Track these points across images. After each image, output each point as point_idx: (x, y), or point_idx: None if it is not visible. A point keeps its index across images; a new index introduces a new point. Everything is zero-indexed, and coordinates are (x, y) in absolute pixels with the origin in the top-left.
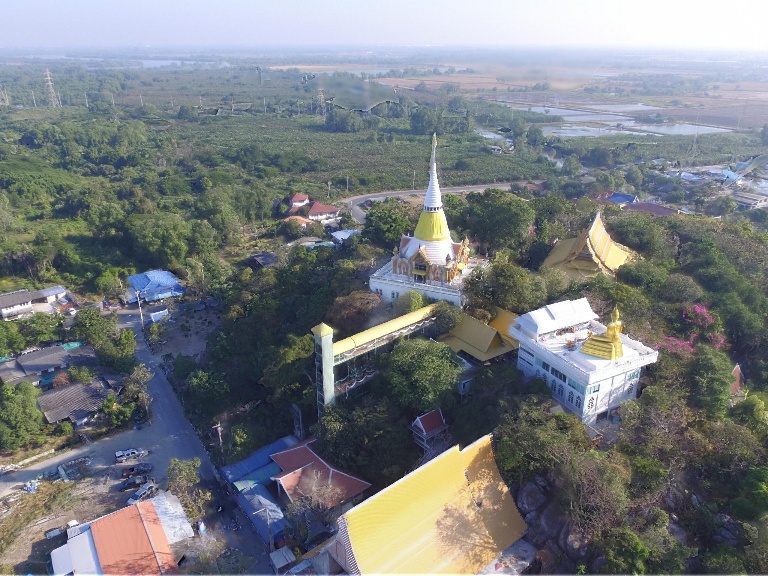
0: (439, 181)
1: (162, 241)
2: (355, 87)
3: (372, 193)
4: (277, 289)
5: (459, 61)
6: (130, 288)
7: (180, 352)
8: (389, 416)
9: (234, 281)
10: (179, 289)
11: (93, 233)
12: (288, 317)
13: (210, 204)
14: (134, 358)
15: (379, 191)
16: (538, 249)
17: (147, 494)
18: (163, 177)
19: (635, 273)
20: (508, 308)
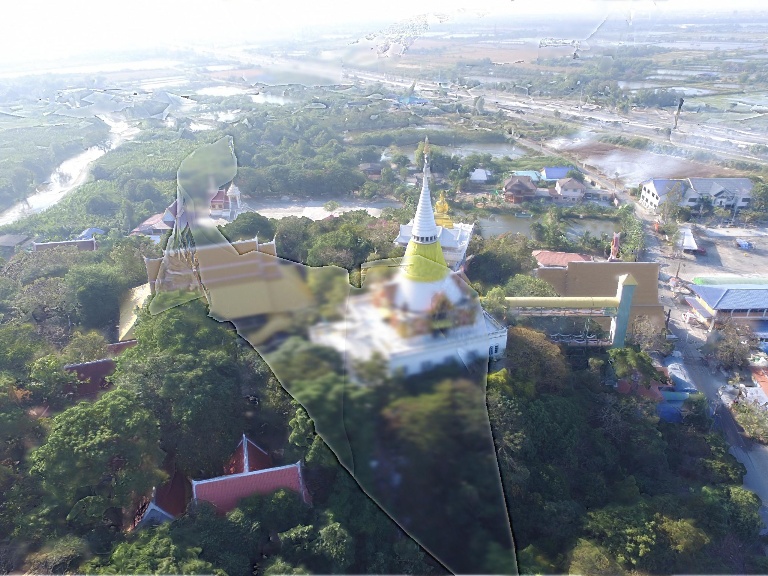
0: None
1: None
2: None
3: None
4: None
5: None
6: None
7: None
8: None
9: None
10: None
11: None
12: (581, 502)
13: None
14: None
15: None
16: None
17: None
18: None
19: None
20: None
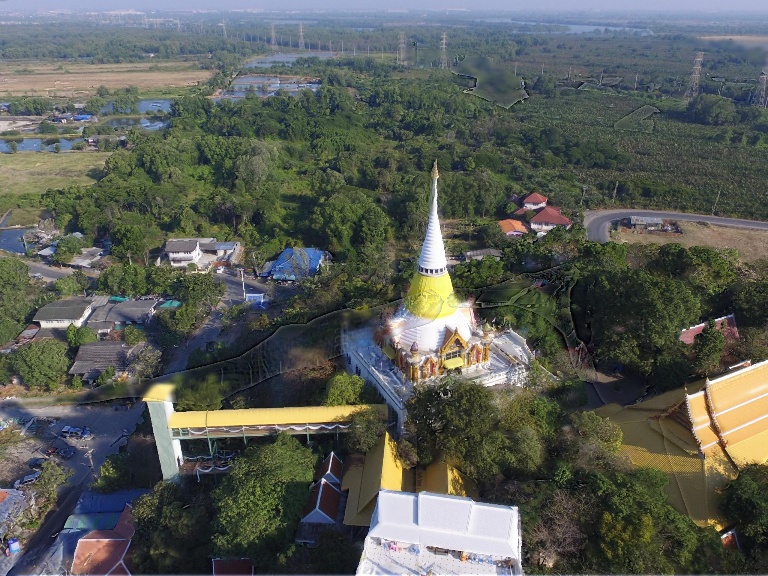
0: (762, 210)
1: (328, 220)
2: (495, 75)
3: (648, 209)
4: (329, 308)
5: (730, 43)
6: (275, 261)
7: (199, 346)
8: (191, 534)
9: (324, 284)
10: (310, 274)
11: (314, 197)
12: None
13: (413, 189)
14: (179, 336)
15: (660, 208)
16: (664, 371)
17: (34, 482)
18: (440, 150)
19: (749, 495)
20: (444, 459)
